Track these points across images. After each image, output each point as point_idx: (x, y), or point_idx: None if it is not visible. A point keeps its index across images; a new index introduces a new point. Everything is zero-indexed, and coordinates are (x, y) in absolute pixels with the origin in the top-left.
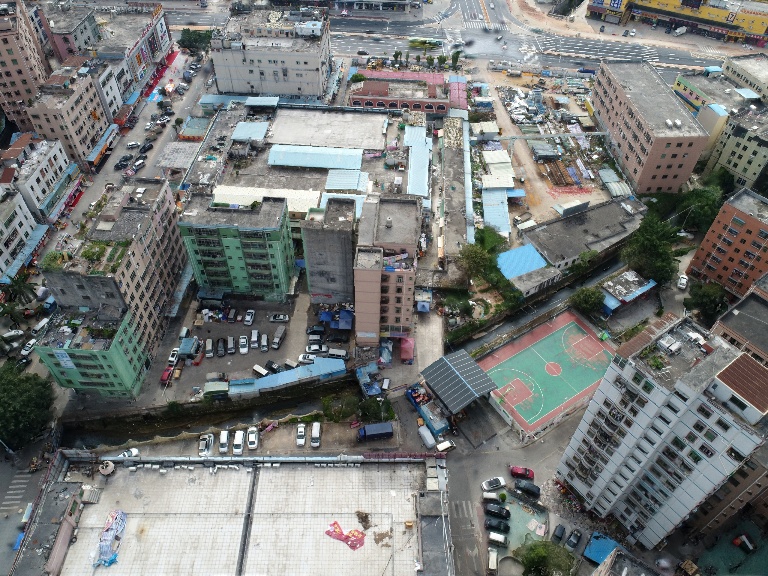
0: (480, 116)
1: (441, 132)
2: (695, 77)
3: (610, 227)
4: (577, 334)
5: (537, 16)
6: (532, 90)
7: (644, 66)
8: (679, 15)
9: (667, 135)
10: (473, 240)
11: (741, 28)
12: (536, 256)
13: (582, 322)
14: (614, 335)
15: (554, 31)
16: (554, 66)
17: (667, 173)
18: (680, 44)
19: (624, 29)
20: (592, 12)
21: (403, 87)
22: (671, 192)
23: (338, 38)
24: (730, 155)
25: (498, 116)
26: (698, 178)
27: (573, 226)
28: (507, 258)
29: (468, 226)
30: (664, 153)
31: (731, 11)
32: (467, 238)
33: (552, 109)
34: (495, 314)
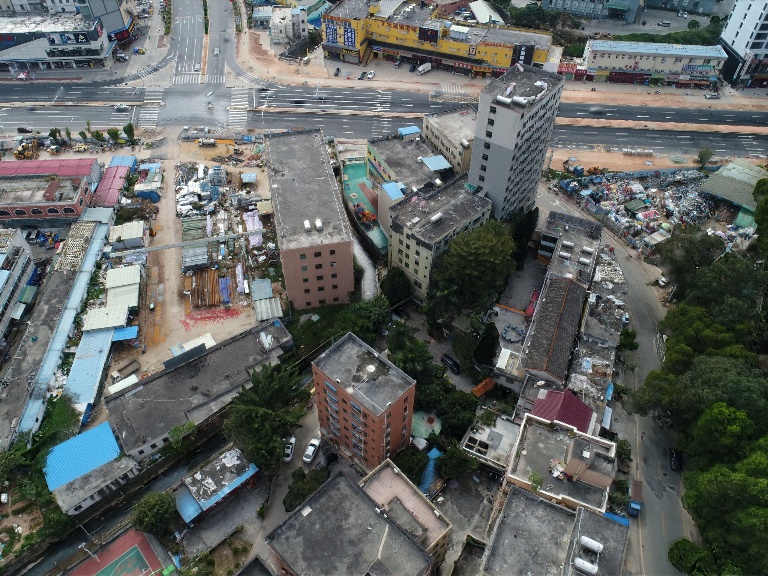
0: (132, 212)
1: (61, 246)
2: (388, 142)
3: (231, 376)
4: (132, 570)
5: (266, 61)
6: (212, 168)
7: (316, 137)
8: (420, 50)
9: (300, 244)
10: (29, 425)
11: (485, 62)
12: (108, 442)
13: (148, 545)
14: (185, 563)
15: (279, 80)
16: (262, 128)
17: (322, 285)
18: (420, 85)
19: (364, 70)
20: (328, 52)
21: (23, 186)
22: (340, 303)
23: (2, 111)
24: (398, 253)
25: (162, 208)
26: (386, 274)
27: (180, 381)
28: (63, 452)
29: (32, 401)
30: (303, 265)
31: (470, 44)
32: (21, 423)
33: (235, 190)
34: (20, 553)
